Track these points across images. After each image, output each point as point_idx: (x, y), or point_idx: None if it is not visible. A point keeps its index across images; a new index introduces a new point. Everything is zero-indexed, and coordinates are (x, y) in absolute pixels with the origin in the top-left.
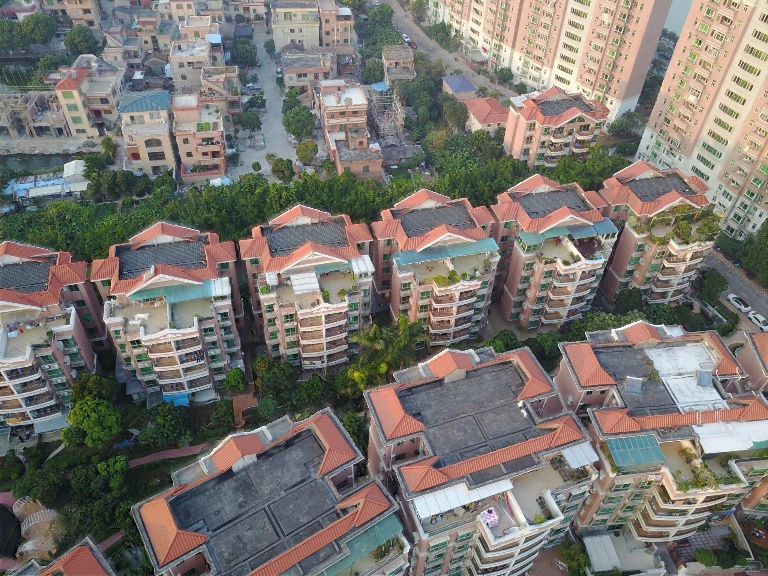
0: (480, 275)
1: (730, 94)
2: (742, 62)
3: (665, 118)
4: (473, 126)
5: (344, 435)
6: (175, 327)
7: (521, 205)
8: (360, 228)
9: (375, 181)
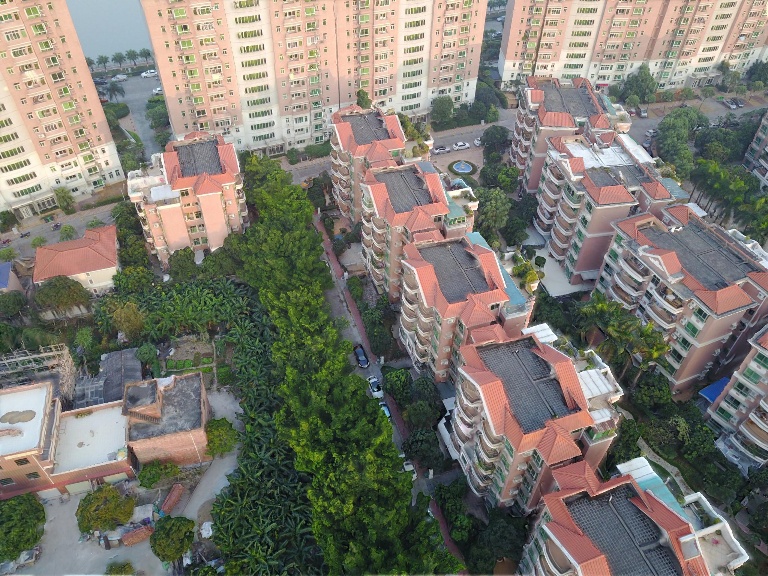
0: (510, 253)
1: (246, 49)
2: (238, 18)
3: (197, 112)
4: (94, 282)
5: (767, 329)
6: (702, 528)
7: (407, 210)
8: (495, 329)
9: (277, 372)
